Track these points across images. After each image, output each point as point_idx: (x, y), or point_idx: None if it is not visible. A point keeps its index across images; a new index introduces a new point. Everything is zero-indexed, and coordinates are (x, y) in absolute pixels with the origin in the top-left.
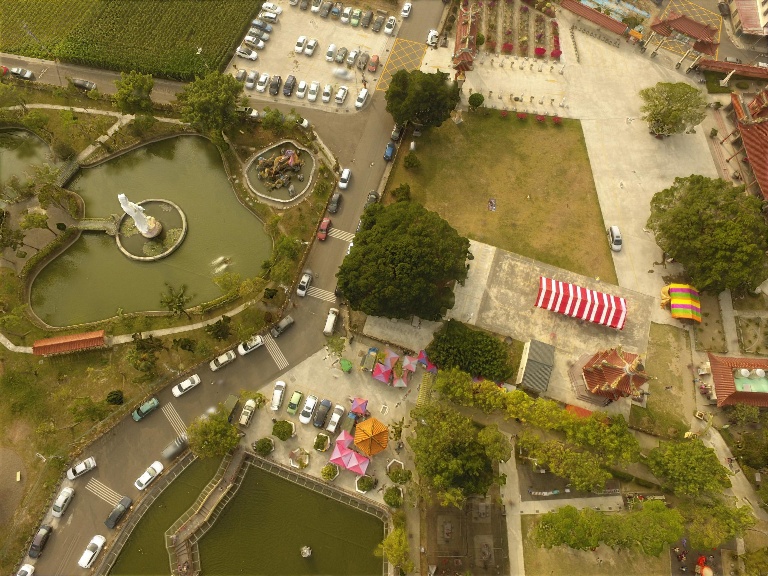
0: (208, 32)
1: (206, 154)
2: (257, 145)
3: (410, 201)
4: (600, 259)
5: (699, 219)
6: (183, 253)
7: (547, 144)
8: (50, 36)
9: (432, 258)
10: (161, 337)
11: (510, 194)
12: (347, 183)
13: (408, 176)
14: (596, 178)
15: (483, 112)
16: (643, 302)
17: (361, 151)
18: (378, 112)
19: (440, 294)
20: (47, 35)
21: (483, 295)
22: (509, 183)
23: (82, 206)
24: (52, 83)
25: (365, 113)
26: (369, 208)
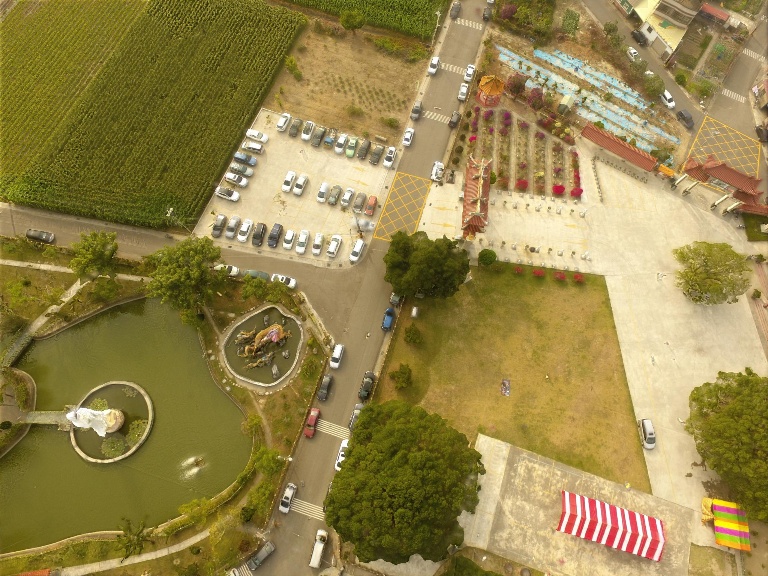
0: (184, 168)
1: (178, 320)
2: (237, 310)
3: (411, 385)
4: (630, 459)
5: (750, 437)
6: (148, 452)
7: (567, 307)
8: (5, 171)
9: (438, 499)
10: (118, 569)
11: (526, 373)
12: (339, 362)
13: (409, 351)
14: (624, 352)
15: (495, 267)
16: (681, 516)
17: (356, 318)
18: (375, 267)
19: (446, 529)
20: (1, 170)
21: (496, 509)
22: (525, 359)
23: (33, 391)
24: (4, 232)
25: (361, 268)
26: (364, 419)
